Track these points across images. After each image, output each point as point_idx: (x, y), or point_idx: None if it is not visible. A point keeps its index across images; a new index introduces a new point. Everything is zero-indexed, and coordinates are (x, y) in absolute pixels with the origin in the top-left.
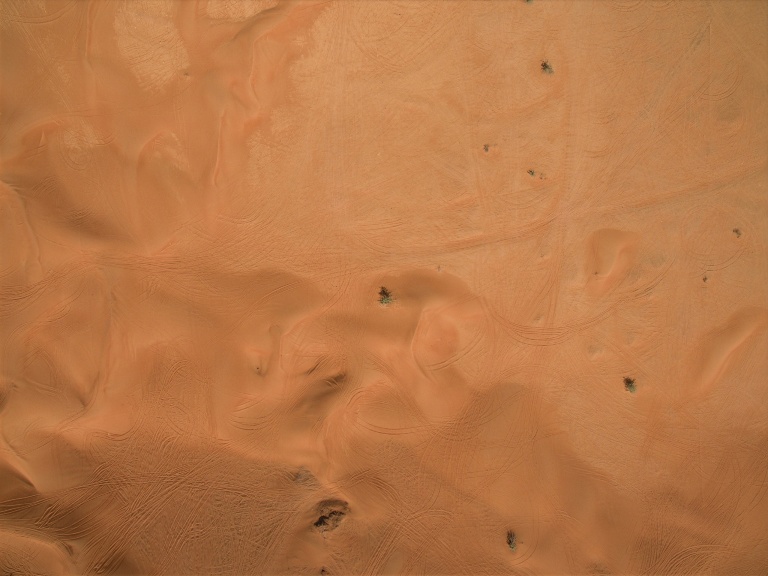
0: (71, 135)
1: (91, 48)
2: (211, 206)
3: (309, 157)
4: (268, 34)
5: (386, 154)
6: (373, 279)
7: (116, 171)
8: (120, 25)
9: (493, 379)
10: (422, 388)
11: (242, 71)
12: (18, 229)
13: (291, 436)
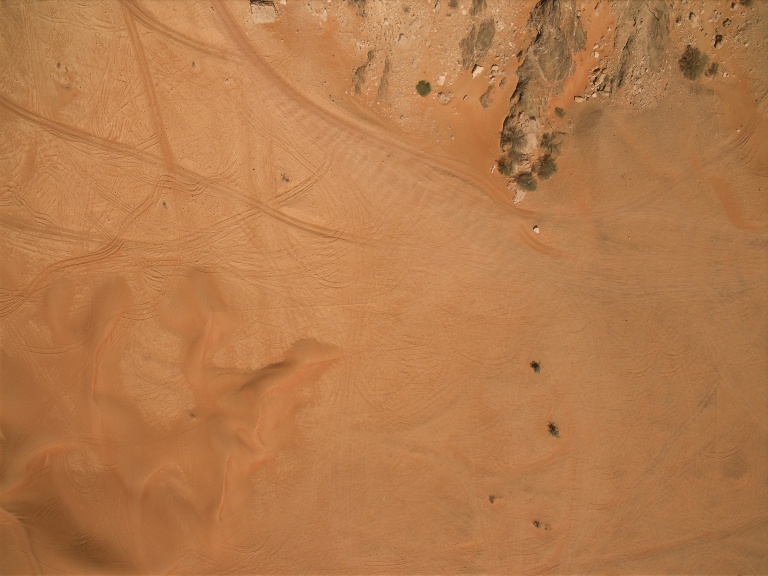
0: (76, 458)
1: (97, 386)
2: (215, 537)
3: (314, 497)
4: (275, 389)
5: (391, 498)
6: None
7: (120, 500)
8: (126, 366)
9: None
10: None
11: (248, 421)
12: (21, 556)
13: None
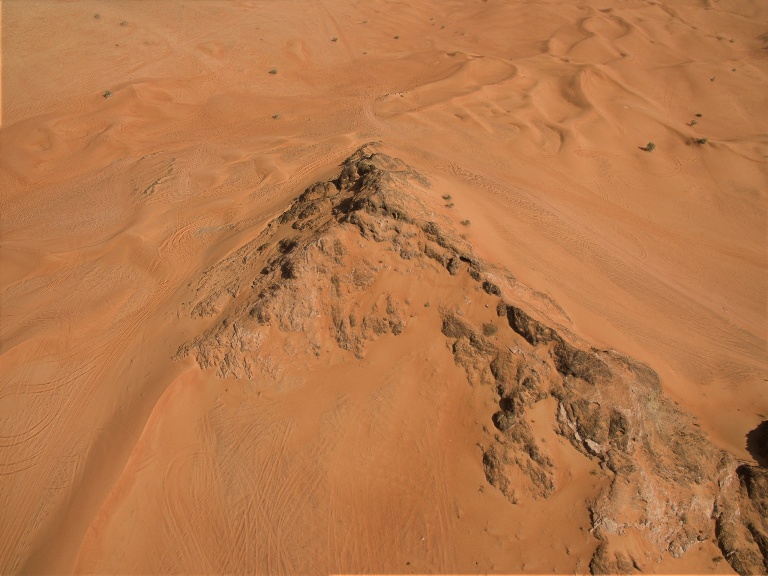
0: None
1: None
2: None
3: (18, 81)
4: None
5: None
6: (95, 96)
7: None
8: None
9: (205, 98)
10: (164, 110)
11: None
12: None
13: (92, 156)
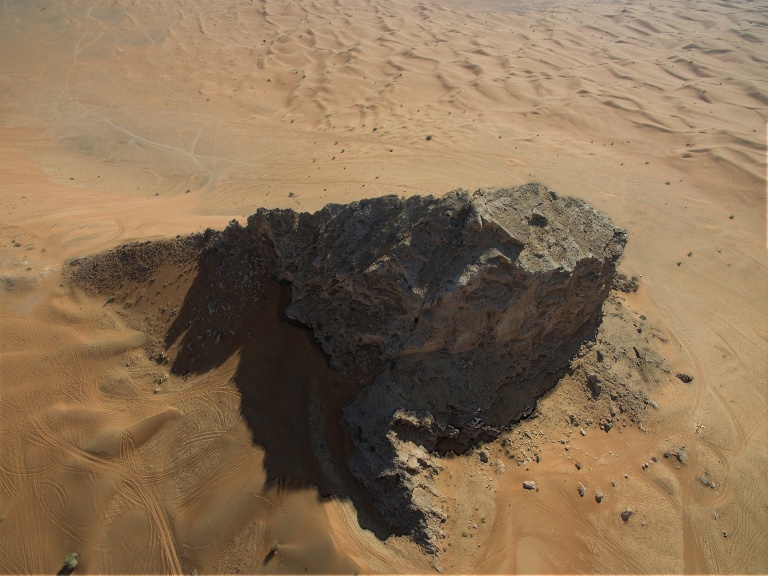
0: None
1: None
2: None
3: None
4: None
5: None
6: None
7: None
8: None
9: None
10: None
11: None
12: None
13: None
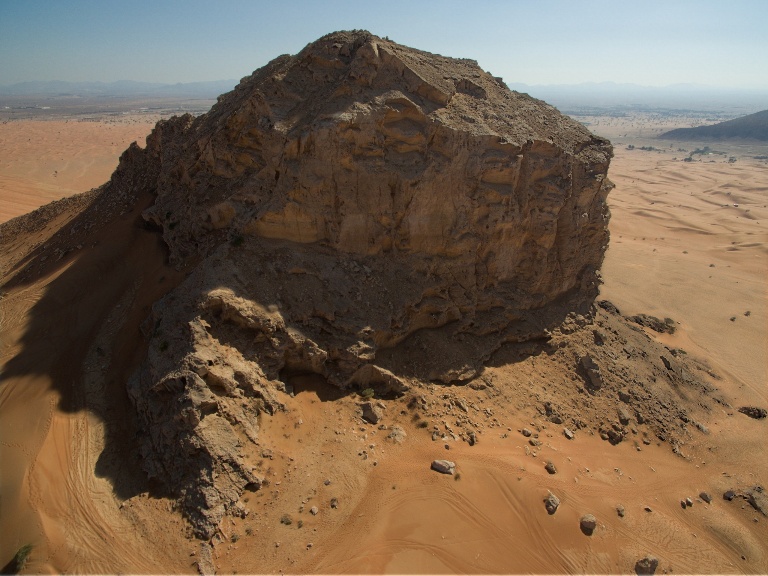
0: None
1: None
2: None
3: None
4: None
5: None
6: None
7: None
8: None
9: None
10: None
11: None
12: None
13: None
